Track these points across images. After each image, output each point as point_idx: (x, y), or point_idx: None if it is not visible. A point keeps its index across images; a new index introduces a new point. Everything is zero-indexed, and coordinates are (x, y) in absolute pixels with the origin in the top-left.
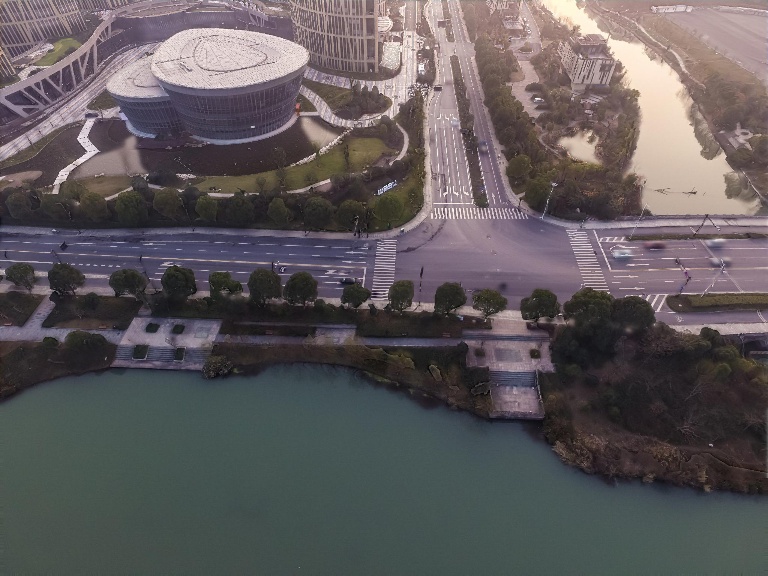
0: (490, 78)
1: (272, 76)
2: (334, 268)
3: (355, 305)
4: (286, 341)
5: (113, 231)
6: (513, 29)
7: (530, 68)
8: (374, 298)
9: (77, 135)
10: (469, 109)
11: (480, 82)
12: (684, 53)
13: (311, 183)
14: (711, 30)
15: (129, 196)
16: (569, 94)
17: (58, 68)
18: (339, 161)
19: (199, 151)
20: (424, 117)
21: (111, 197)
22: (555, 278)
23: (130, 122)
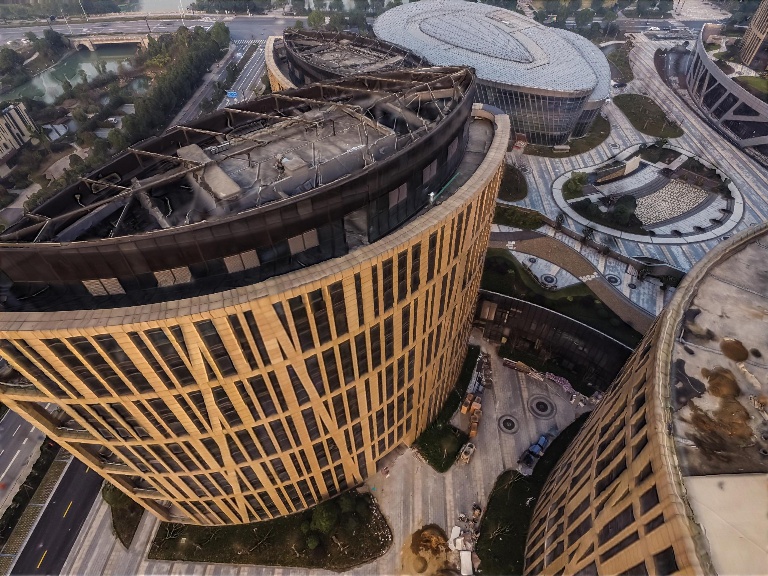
0: (167, 86)
1: (401, 8)
2: None
3: None
4: None
5: None
6: None
7: (35, 186)
8: None
9: None
10: None
11: None
12: None
13: None
14: None
15: None
16: None
17: None
18: None
19: None
20: None
21: None
22: None
23: None
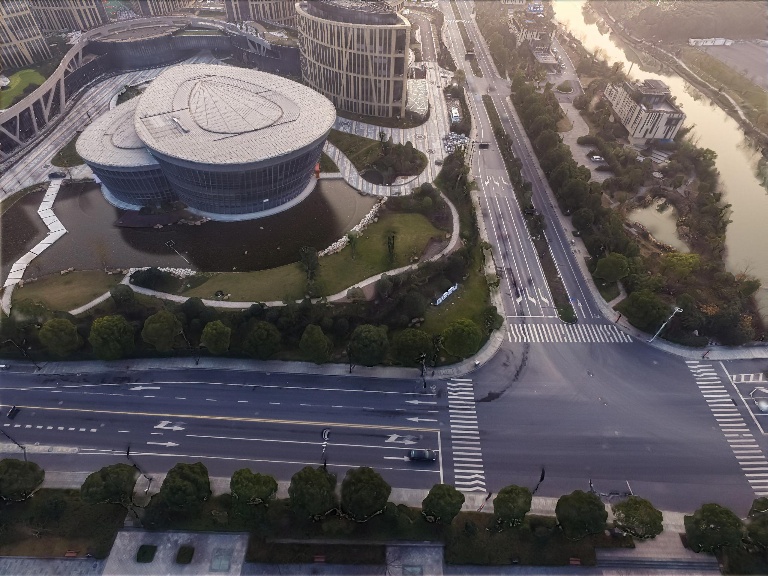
0: (546, 135)
1: (295, 144)
2: (396, 431)
3: (446, 522)
4: (345, 574)
5: (86, 365)
6: (547, 63)
7: (575, 113)
8: (460, 488)
9: (38, 205)
10: (520, 170)
11: (524, 132)
12: (737, 96)
13: (347, 285)
14: (759, 69)
15: (109, 326)
16: (635, 154)
17: (14, 113)
18: (378, 249)
19: (197, 231)
20: (477, 188)
21: (83, 308)
22: (695, 447)
23: (107, 188)
